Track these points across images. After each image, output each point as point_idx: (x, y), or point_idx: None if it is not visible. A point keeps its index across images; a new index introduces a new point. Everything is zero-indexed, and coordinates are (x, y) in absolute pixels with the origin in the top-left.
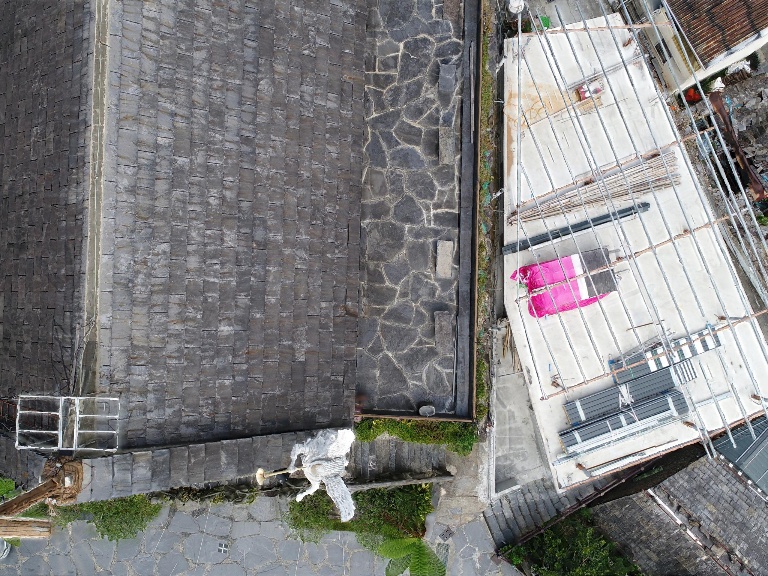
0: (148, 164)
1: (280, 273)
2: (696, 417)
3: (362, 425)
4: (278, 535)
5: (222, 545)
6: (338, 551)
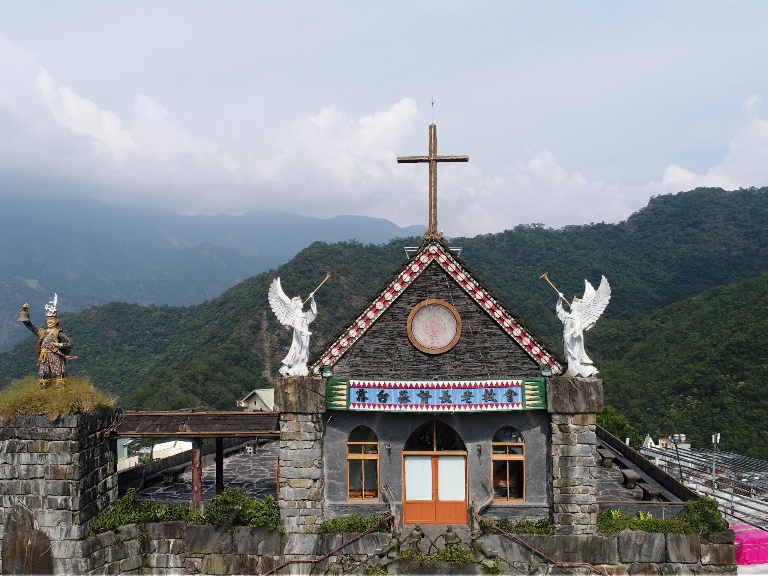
0: None
1: None
2: None
3: (601, 514)
4: None
5: None
6: None
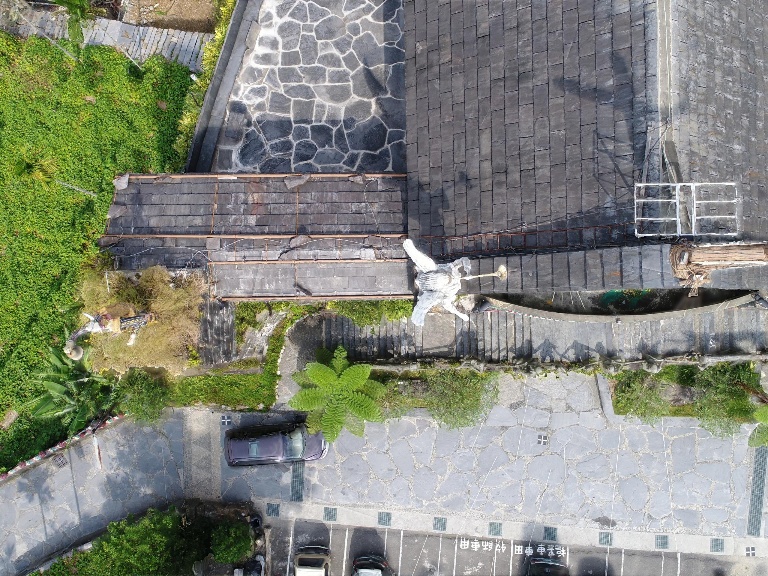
0: None
1: (763, 99)
2: None
3: None
4: (597, 425)
5: (541, 437)
6: (658, 438)
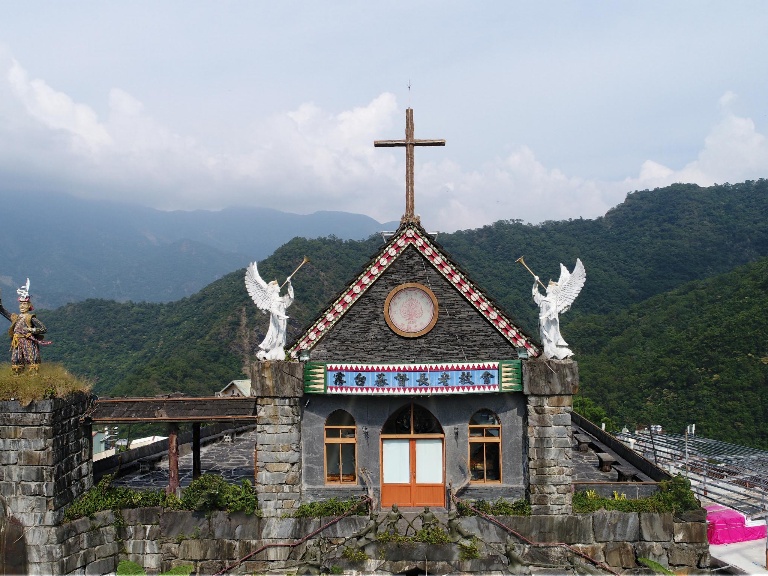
0: None
1: None
2: None
3: (577, 494)
4: None
5: None
6: None
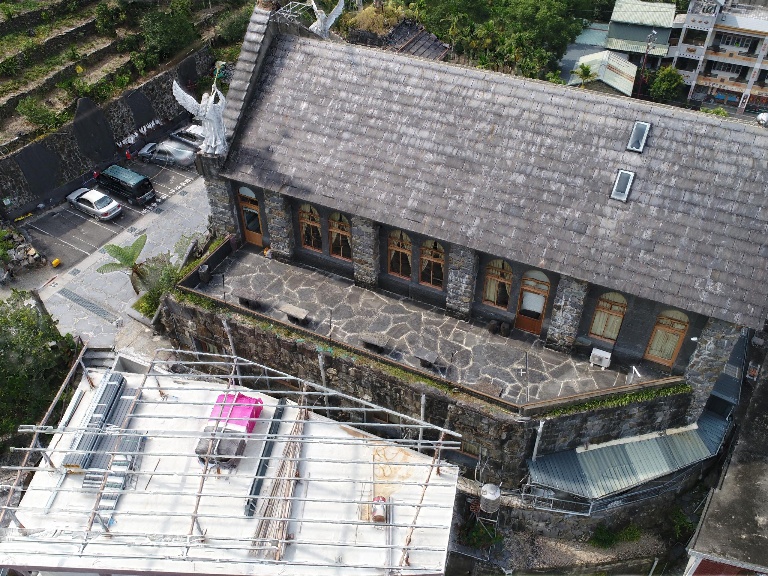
0: (398, 79)
1: (322, 144)
2: (59, 430)
3: None
4: None
5: None
6: None
